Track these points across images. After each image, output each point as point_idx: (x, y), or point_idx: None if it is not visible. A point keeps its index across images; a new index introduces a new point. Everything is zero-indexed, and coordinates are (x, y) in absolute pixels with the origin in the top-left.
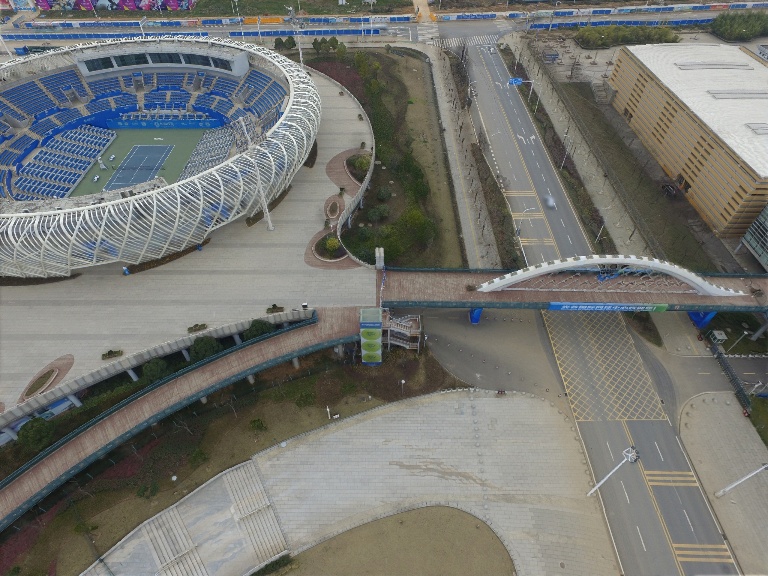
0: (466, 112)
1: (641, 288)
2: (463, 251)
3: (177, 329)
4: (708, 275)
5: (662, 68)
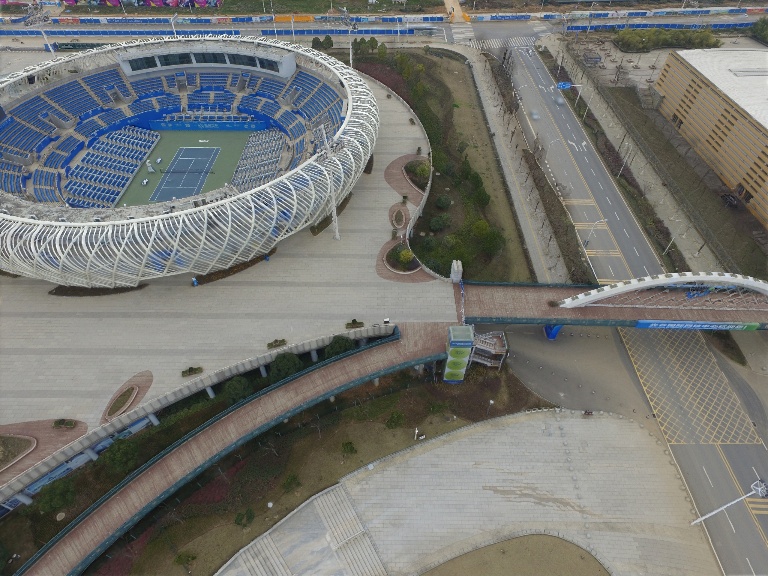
0: None
1: (728, 305)
2: (529, 262)
3: (255, 345)
4: None
5: (716, 74)
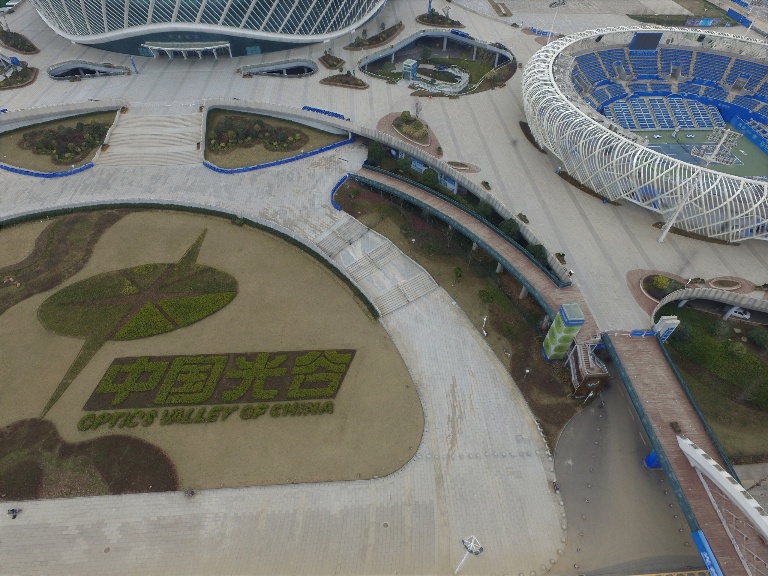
0: None
1: None
2: None
3: (519, 209)
4: None
5: None
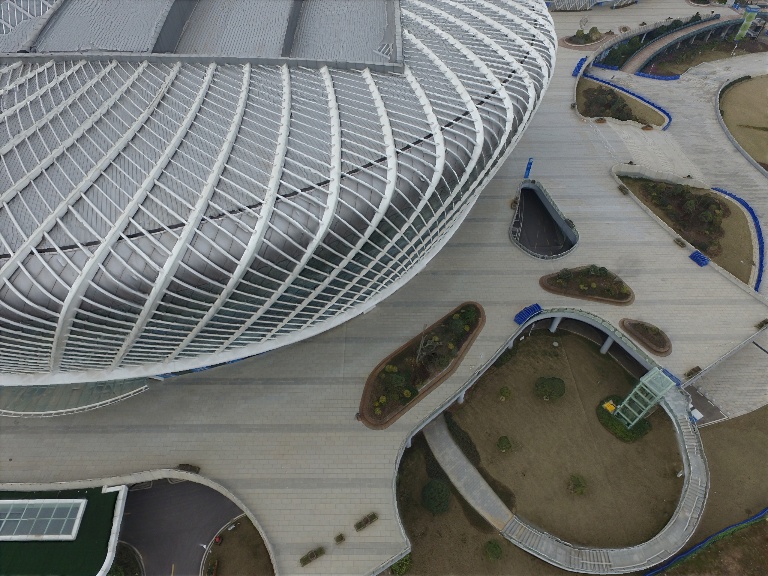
0: None
1: None
2: None
3: (660, 20)
4: None
5: None
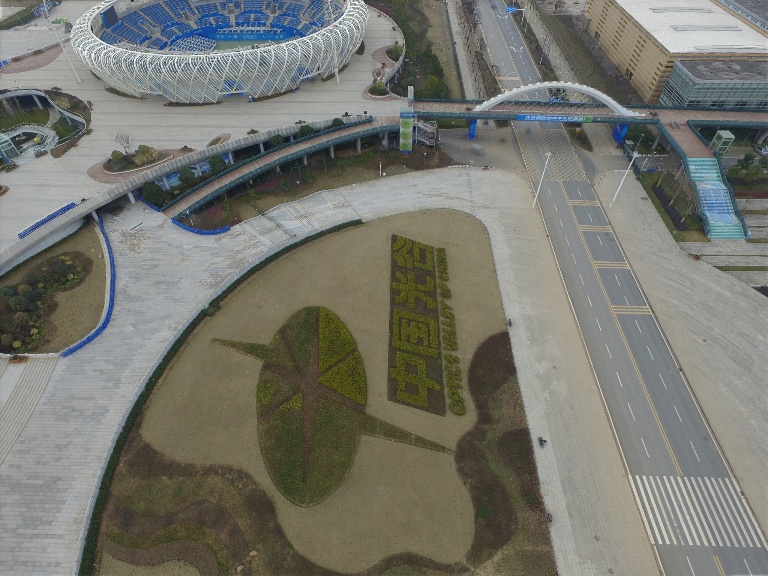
0: (472, 33)
1: None
2: None
3: (288, 124)
4: (624, 106)
5: None
